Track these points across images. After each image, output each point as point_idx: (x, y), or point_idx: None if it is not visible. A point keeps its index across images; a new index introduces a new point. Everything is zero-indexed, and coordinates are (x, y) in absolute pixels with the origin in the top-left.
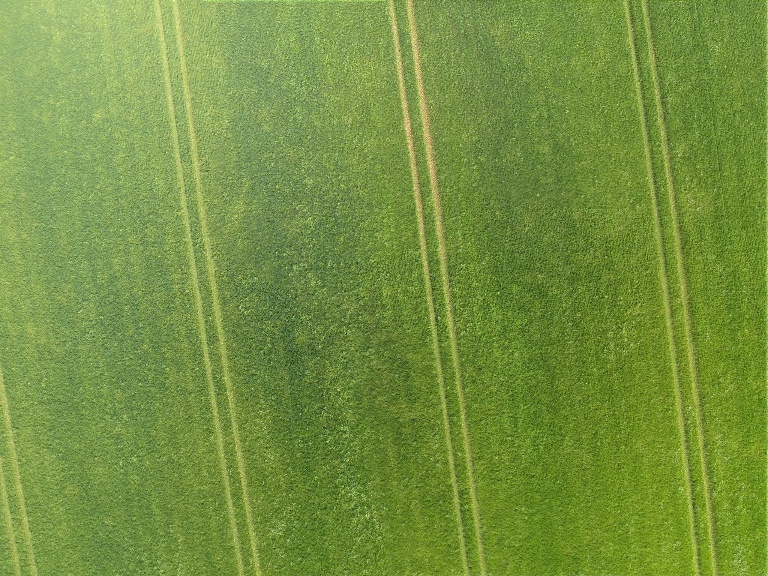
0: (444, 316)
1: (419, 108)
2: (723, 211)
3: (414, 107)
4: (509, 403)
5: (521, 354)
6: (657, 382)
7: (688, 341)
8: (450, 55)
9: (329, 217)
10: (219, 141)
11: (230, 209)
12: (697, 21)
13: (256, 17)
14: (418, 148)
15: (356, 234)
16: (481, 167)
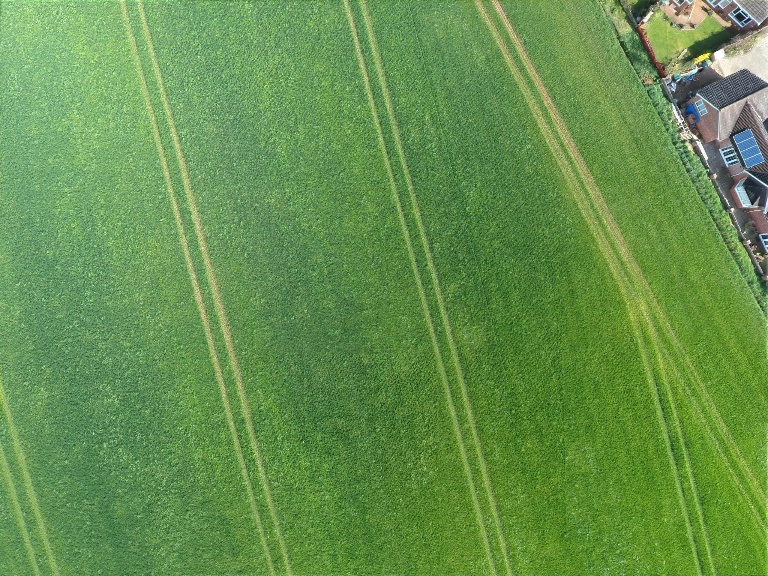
0: (255, 471)
1: (206, 277)
2: (495, 341)
3: (201, 277)
4: (327, 542)
5: (332, 495)
6: (458, 502)
7: (481, 461)
8: (230, 224)
9: (132, 392)
10: (13, 332)
11: (33, 397)
12: (451, 170)
13: (35, 207)
14: (210, 316)
15: (161, 405)
16: (272, 327)
